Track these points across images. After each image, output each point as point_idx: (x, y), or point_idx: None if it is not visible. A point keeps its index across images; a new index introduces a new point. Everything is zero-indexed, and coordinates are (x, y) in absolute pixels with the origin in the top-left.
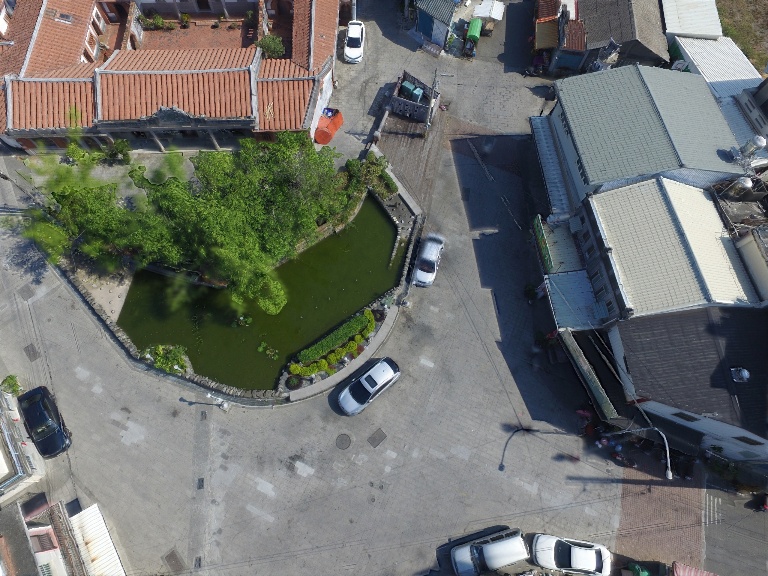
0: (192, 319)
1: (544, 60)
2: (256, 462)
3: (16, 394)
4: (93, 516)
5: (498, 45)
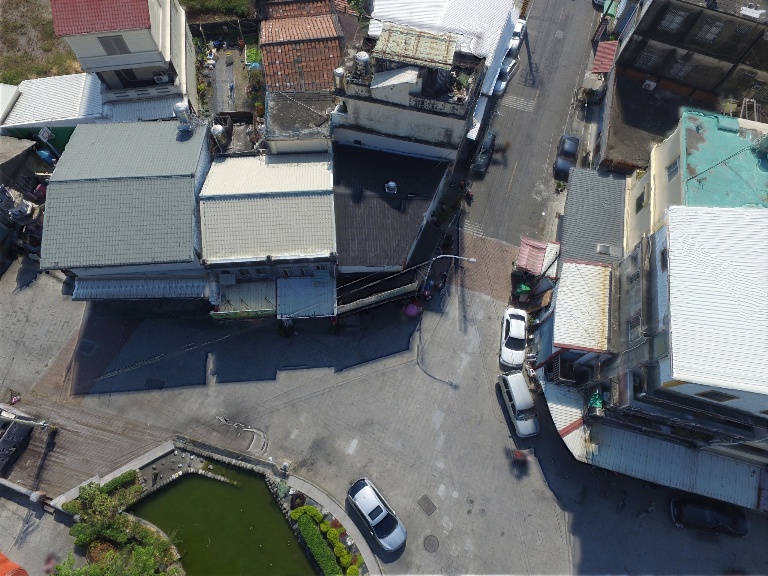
0: None
1: None
2: None
3: None
4: None
5: None
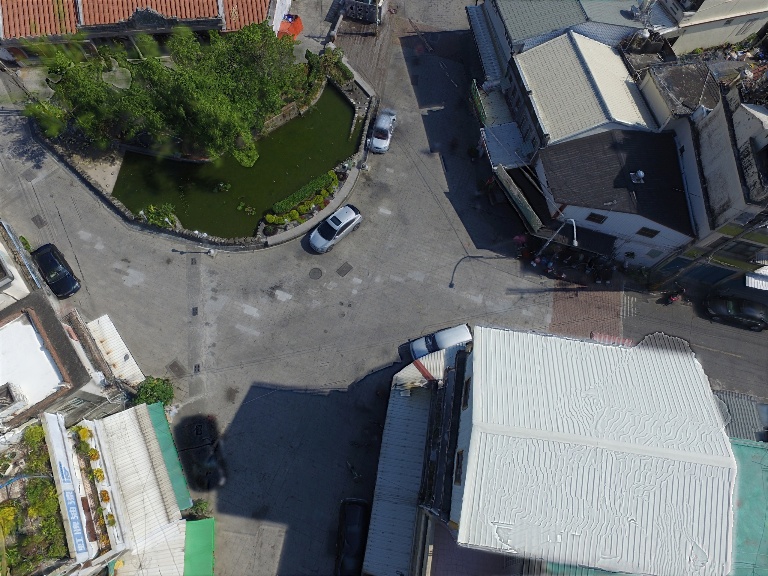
0: (178, 188)
1: None
2: (242, 293)
3: (29, 251)
4: (105, 323)
5: None
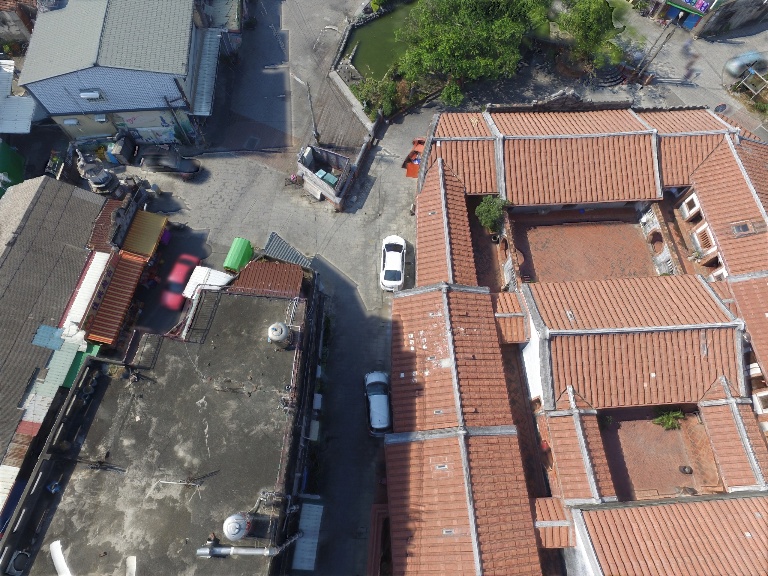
0: None
1: None
2: None
3: None
4: None
5: None
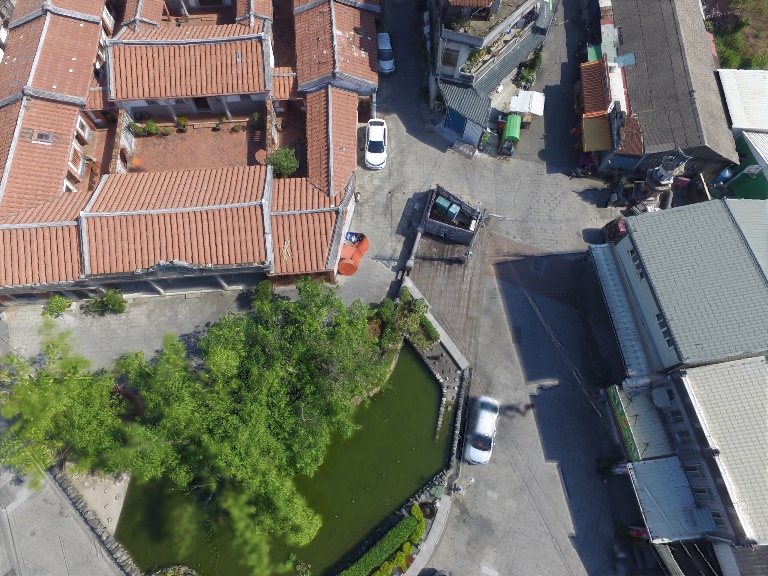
0: (205, 524)
1: (593, 160)
2: None
3: None
4: None
5: (537, 139)
